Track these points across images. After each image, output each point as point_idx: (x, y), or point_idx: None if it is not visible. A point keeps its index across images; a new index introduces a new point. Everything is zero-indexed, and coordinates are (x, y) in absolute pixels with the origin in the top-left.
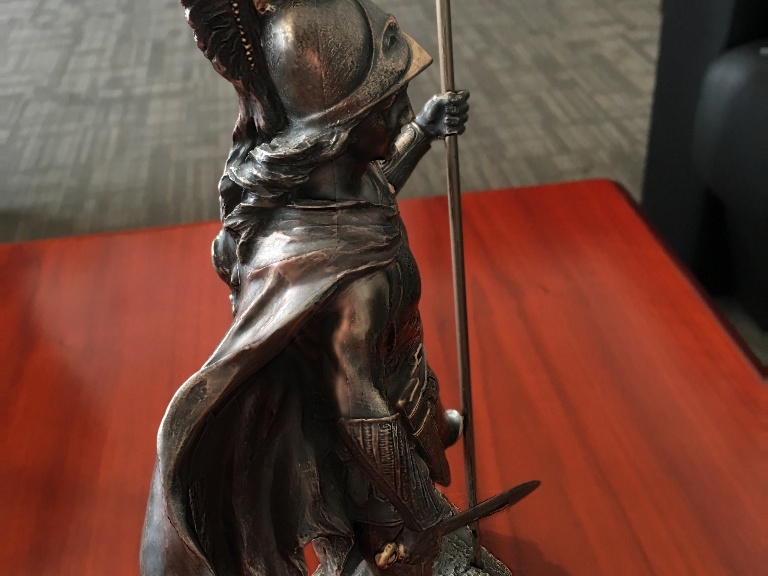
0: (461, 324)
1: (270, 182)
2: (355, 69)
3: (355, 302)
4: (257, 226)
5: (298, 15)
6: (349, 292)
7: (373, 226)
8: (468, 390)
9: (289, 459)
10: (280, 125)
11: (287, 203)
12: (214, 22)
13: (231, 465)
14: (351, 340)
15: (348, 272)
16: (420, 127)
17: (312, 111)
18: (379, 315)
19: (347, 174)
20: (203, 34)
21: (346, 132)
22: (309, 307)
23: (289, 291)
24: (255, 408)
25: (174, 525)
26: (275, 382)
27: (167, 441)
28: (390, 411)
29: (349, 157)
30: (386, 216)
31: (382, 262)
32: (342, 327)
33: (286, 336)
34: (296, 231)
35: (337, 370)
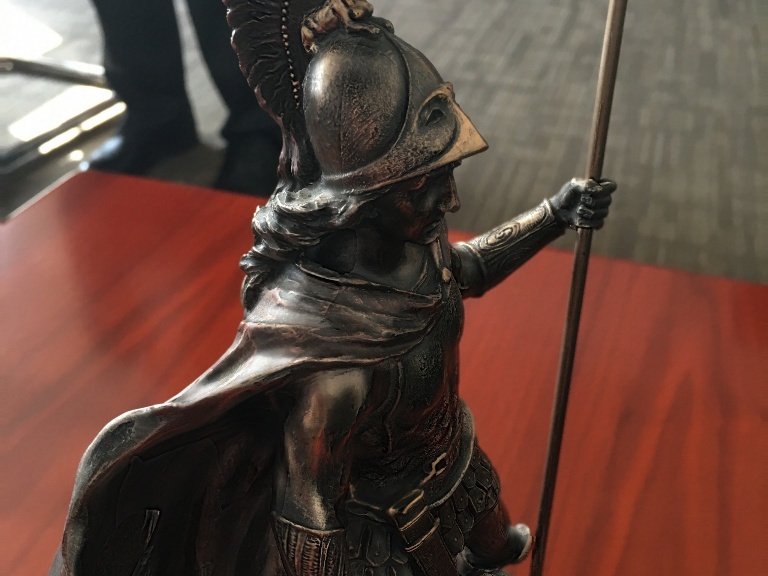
0: (553, 438)
1: (277, 234)
2: (378, 137)
3: (314, 394)
4: (266, 275)
5: (330, 63)
6: (311, 381)
7: (378, 314)
8: (547, 512)
9: (266, 522)
10: (316, 175)
11: (296, 261)
12: (262, 50)
13: (200, 507)
14: (301, 433)
15: (308, 360)
16: (552, 209)
17: (332, 171)
18: (341, 416)
19: (372, 248)
20: (248, 60)
21: (356, 205)
22: (246, 385)
23: (253, 358)
24: (236, 459)
25: (63, 555)
26: (265, 440)
27: (84, 469)
28: (327, 524)
29: (375, 231)
30: (410, 306)
31: (362, 359)
32: (295, 416)
33: (218, 407)
34: (290, 295)
35: (282, 459)
